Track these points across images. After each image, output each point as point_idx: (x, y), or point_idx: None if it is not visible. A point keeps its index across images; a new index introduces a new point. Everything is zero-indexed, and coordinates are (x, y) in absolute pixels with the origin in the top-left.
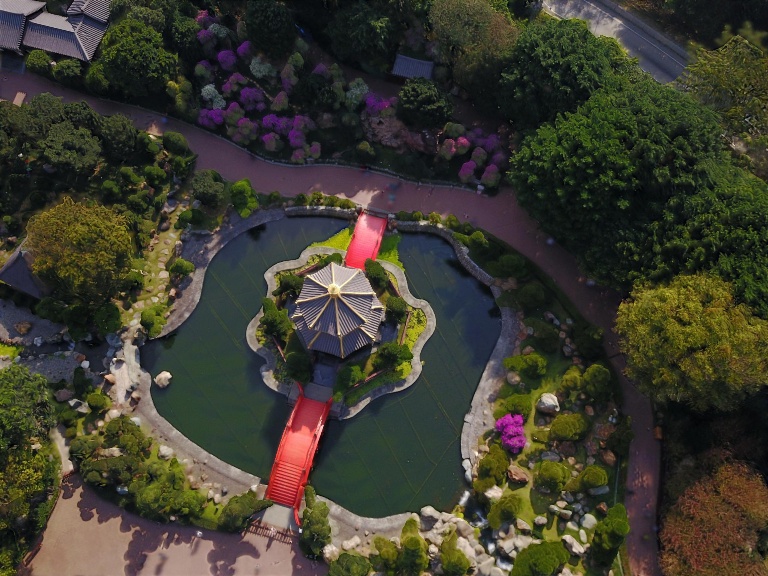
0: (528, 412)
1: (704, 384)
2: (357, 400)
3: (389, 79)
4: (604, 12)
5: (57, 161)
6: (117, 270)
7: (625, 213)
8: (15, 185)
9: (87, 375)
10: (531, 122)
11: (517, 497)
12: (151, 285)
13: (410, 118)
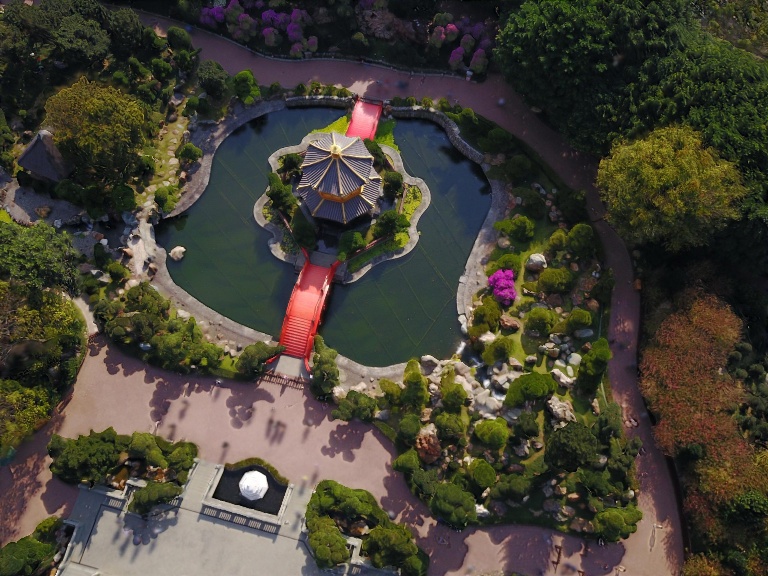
0: (518, 269)
1: (676, 217)
2: (359, 267)
3: None
4: None
5: (70, 48)
6: (132, 145)
7: (603, 77)
8: (29, 81)
9: (106, 251)
10: (515, 3)
11: (509, 338)
12: (162, 170)
13: (401, 10)
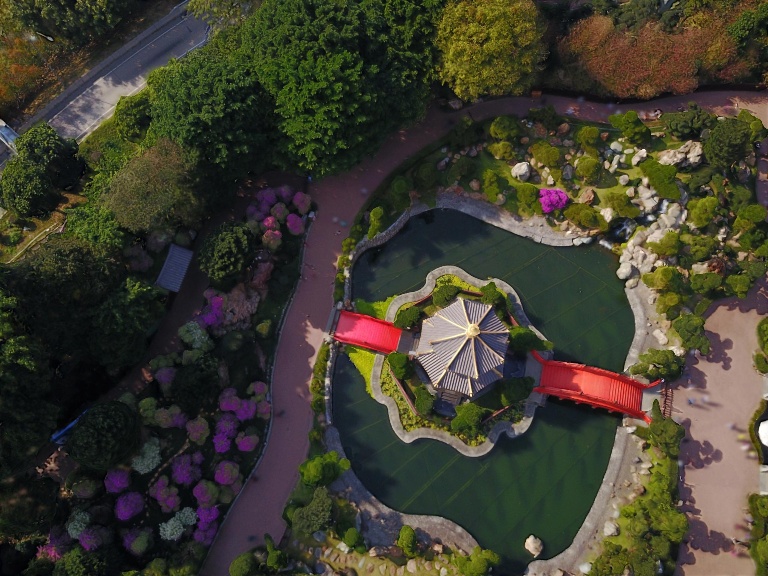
0: None
1: (538, 32)
2: None
3: (170, 305)
4: (84, 92)
5: None
6: None
7: None
8: None
9: None
10: (266, 146)
11: (610, 195)
12: None
13: None
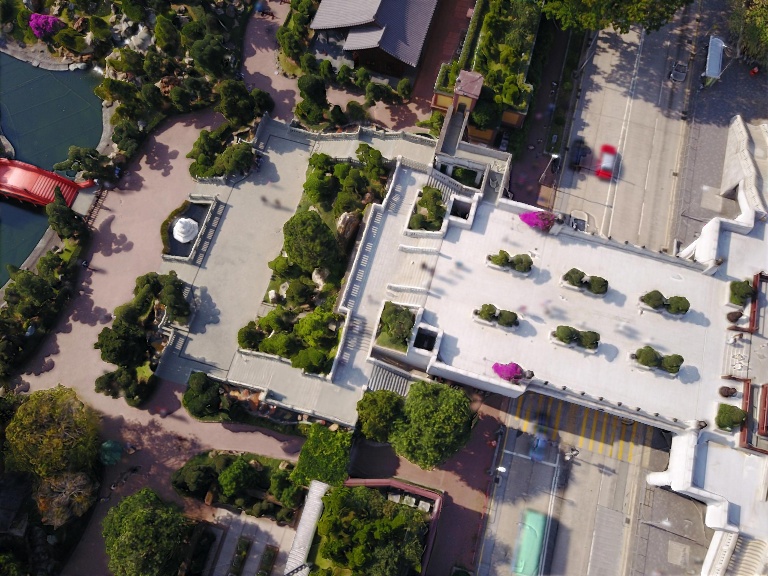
0: None
1: None
2: None
3: None
4: None
5: None
6: None
7: None
8: None
9: None
10: None
11: None
12: None
13: None
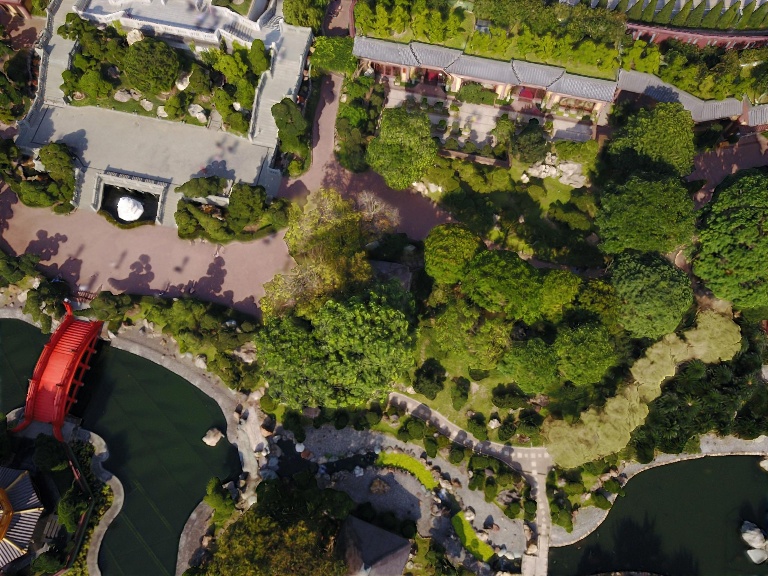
0: None
1: None
2: None
3: None
4: None
5: None
6: None
7: None
8: None
9: None
10: None
11: None
12: None
13: None
